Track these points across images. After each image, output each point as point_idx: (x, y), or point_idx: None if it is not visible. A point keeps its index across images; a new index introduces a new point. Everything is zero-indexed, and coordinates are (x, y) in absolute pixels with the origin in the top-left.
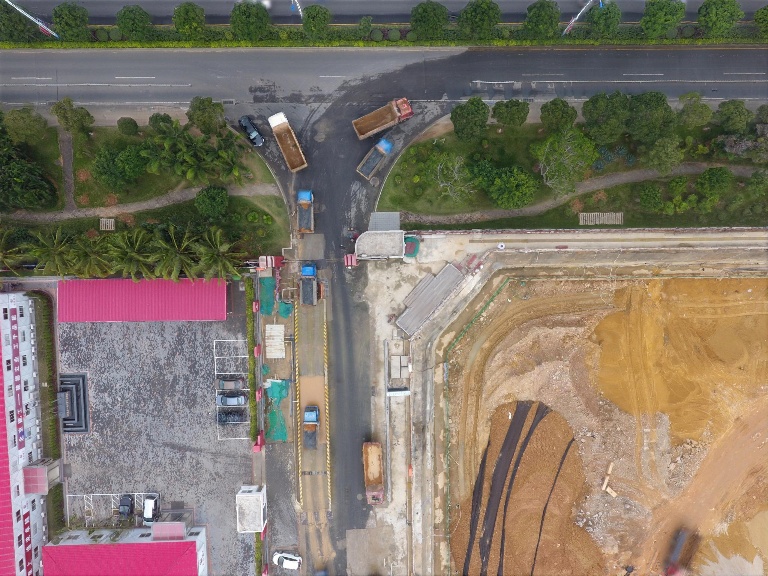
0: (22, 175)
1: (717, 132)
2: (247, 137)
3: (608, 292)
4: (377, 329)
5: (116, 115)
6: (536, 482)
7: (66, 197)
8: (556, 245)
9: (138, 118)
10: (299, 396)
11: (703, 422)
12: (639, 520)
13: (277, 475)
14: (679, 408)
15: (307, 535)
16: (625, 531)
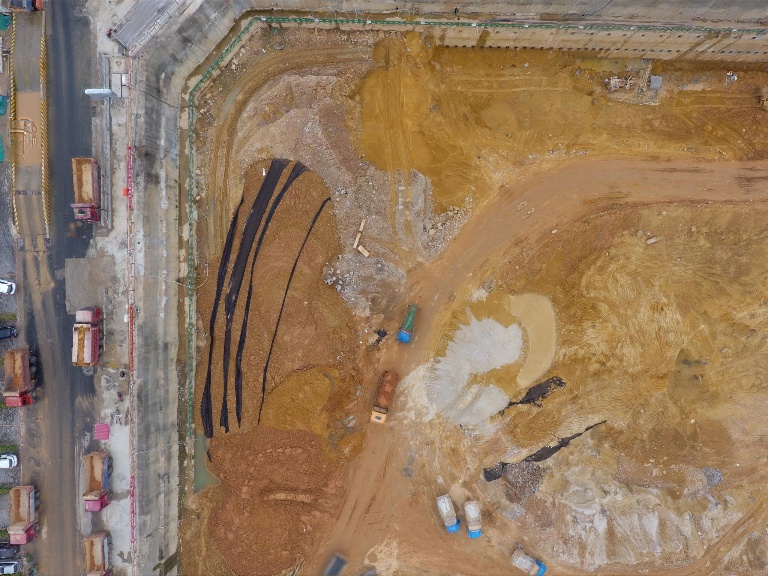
0: None
1: None
2: None
3: (367, 46)
4: (99, 46)
5: None
6: (286, 238)
7: None
8: None
9: None
10: (15, 112)
11: (465, 187)
12: (392, 281)
13: None
14: (441, 172)
15: (24, 263)
16: (377, 293)
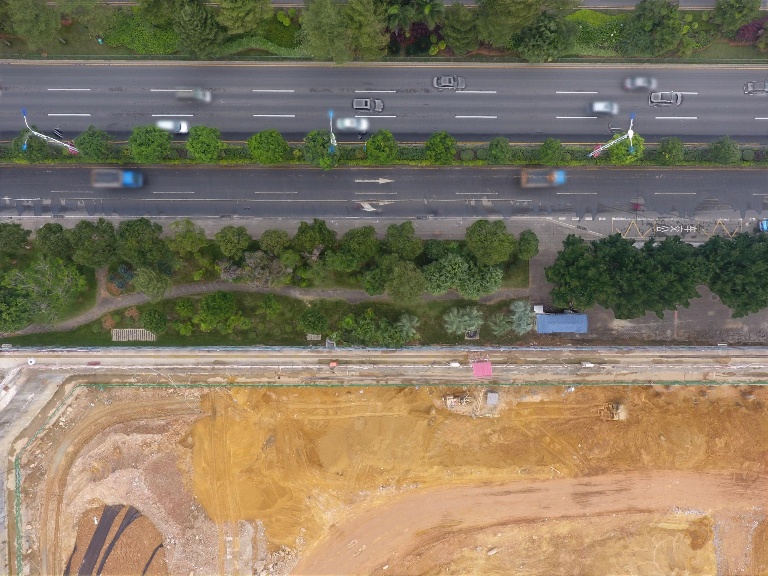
0: None
1: None
2: None
3: (194, 397)
4: None
5: None
6: None
7: None
8: (88, 361)
9: None
10: None
11: (295, 529)
12: None
13: None
14: (271, 514)
15: None
16: None
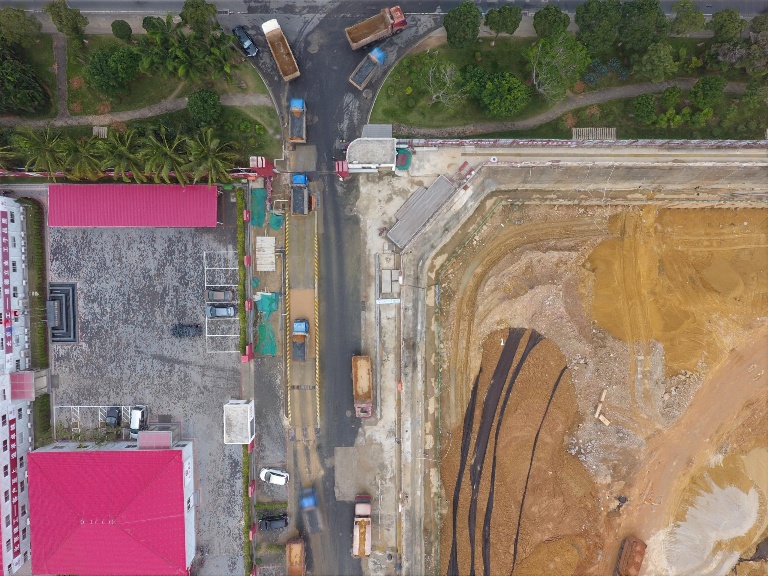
0: (16, 74)
1: (711, 45)
2: (241, 46)
3: (602, 218)
4: (368, 243)
5: (111, 23)
6: (528, 409)
7: (60, 105)
8: (549, 159)
9: (133, 27)
10: (289, 309)
11: (698, 352)
12: (632, 449)
13: (265, 390)
14: (673, 337)
15: (295, 452)
16: (618, 460)
